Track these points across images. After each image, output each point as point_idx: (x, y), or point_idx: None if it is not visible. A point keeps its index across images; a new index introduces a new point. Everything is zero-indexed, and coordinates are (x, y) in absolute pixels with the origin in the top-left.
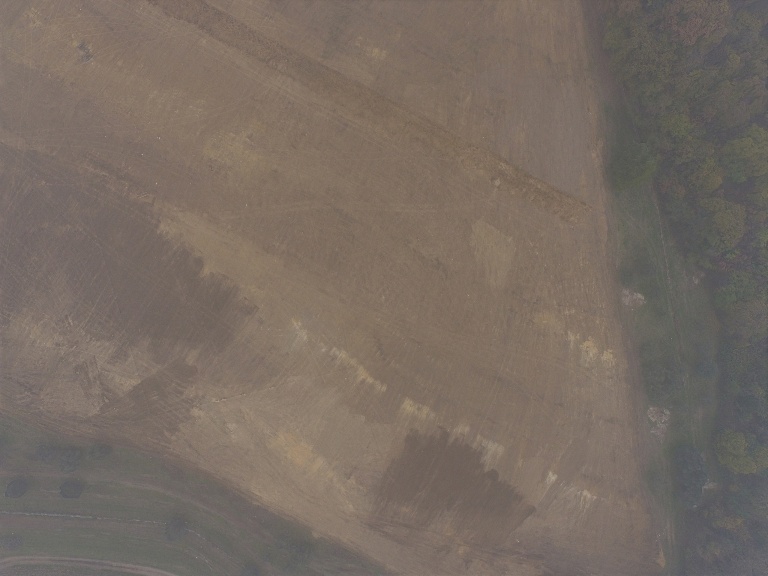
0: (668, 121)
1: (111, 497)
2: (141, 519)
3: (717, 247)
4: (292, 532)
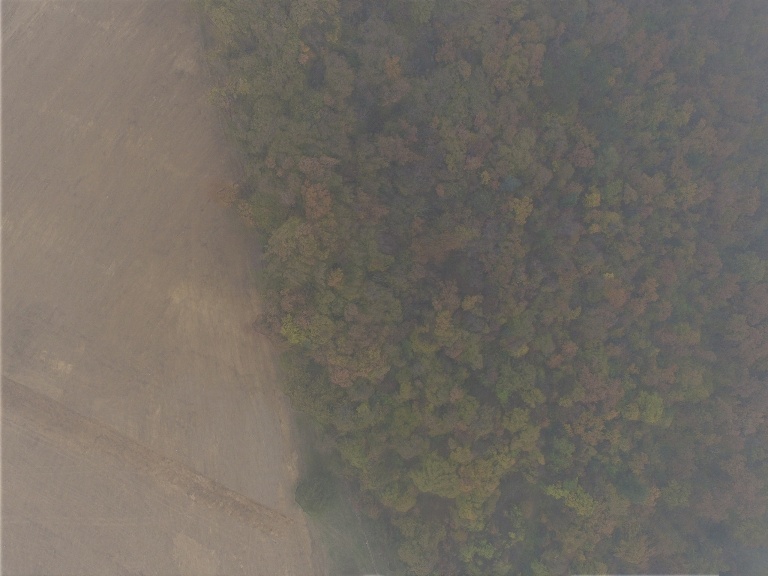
0: (344, 451)
1: None
2: None
3: (410, 575)
4: None
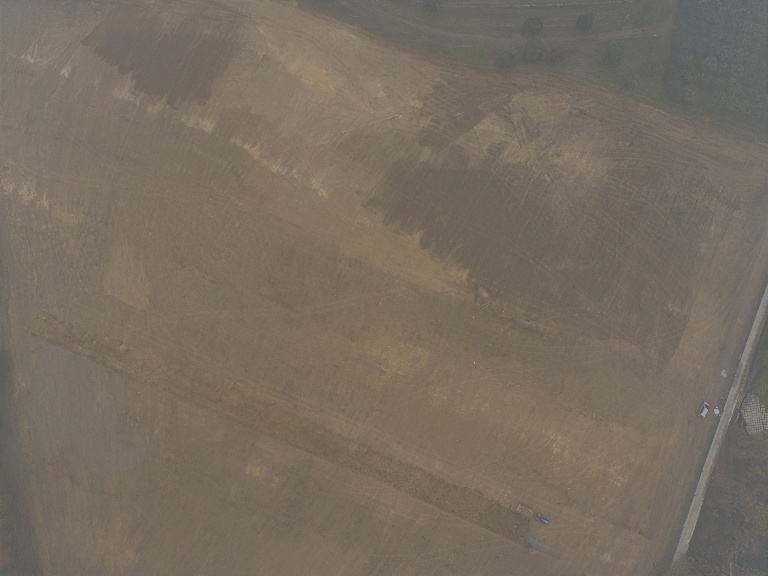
0: None
1: (499, 25)
2: (468, 8)
3: None
4: (319, 5)
